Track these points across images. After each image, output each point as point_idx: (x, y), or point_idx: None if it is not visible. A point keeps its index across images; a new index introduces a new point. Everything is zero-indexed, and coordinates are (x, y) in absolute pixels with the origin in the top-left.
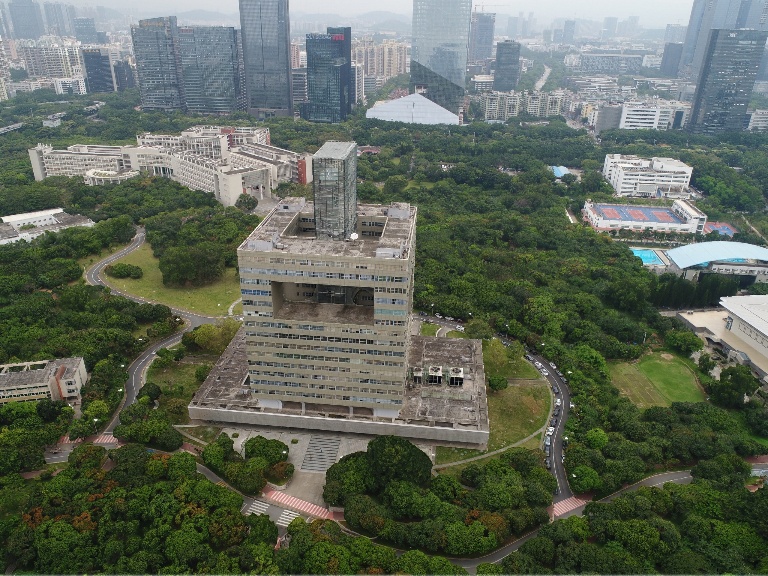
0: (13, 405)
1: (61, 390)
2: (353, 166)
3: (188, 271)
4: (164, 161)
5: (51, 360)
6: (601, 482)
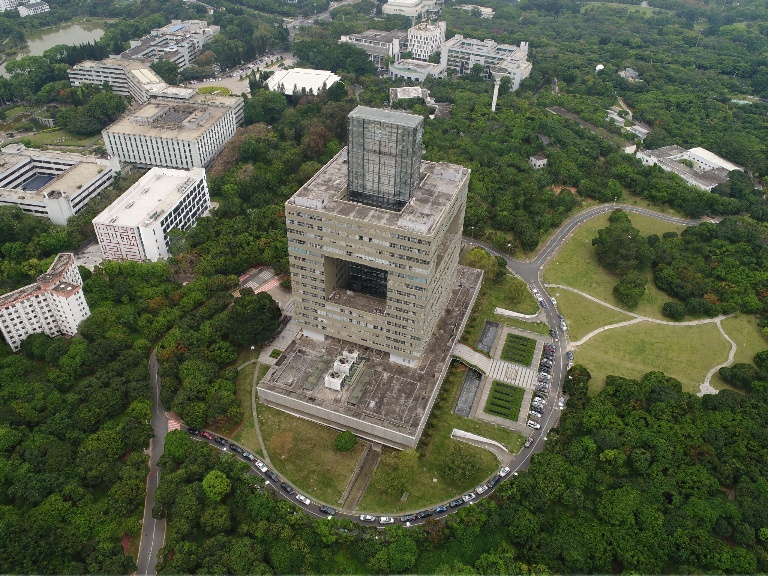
0: None
1: None
2: (394, 142)
3: (604, 245)
4: None
5: None
6: (165, 452)
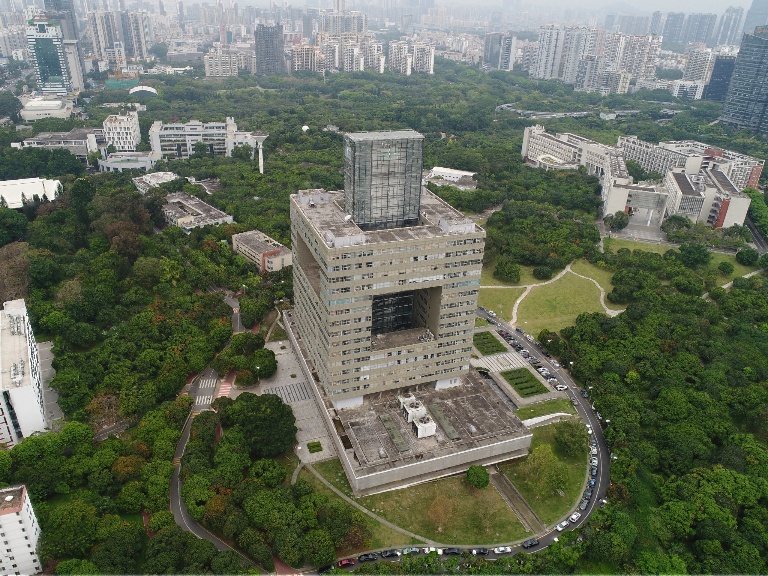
0: (238, 257)
1: (265, 264)
2: (403, 158)
3: None
4: (604, 163)
5: (283, 246)
6: None
